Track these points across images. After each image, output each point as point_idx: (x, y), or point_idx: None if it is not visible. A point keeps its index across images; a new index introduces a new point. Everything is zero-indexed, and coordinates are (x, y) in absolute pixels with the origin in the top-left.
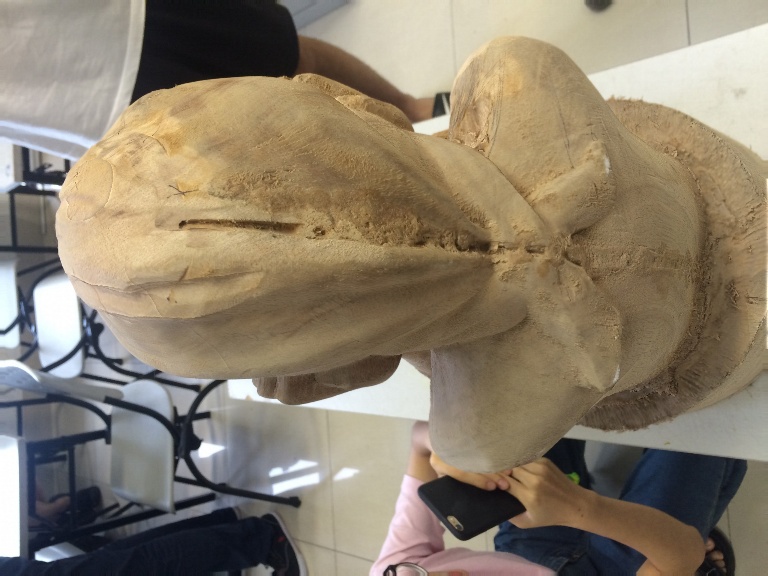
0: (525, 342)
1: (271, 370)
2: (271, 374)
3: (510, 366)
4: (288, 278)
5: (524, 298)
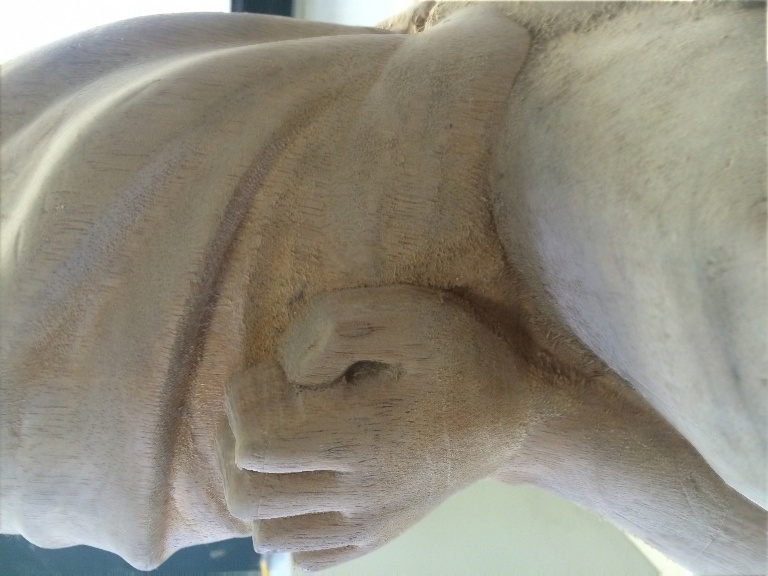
0: (569, 53)
1: (44, 204)
2: (52, 218)
3: (582, 89)
4: (20, 59)
5: (487, 9)
